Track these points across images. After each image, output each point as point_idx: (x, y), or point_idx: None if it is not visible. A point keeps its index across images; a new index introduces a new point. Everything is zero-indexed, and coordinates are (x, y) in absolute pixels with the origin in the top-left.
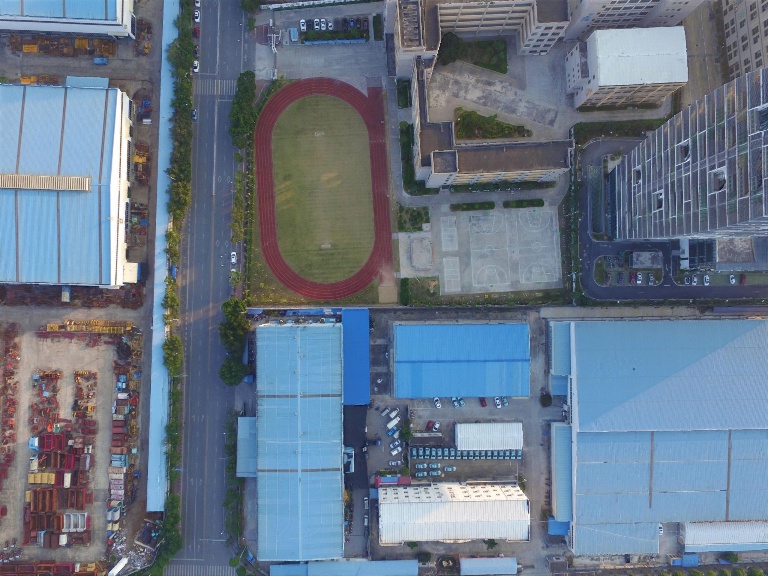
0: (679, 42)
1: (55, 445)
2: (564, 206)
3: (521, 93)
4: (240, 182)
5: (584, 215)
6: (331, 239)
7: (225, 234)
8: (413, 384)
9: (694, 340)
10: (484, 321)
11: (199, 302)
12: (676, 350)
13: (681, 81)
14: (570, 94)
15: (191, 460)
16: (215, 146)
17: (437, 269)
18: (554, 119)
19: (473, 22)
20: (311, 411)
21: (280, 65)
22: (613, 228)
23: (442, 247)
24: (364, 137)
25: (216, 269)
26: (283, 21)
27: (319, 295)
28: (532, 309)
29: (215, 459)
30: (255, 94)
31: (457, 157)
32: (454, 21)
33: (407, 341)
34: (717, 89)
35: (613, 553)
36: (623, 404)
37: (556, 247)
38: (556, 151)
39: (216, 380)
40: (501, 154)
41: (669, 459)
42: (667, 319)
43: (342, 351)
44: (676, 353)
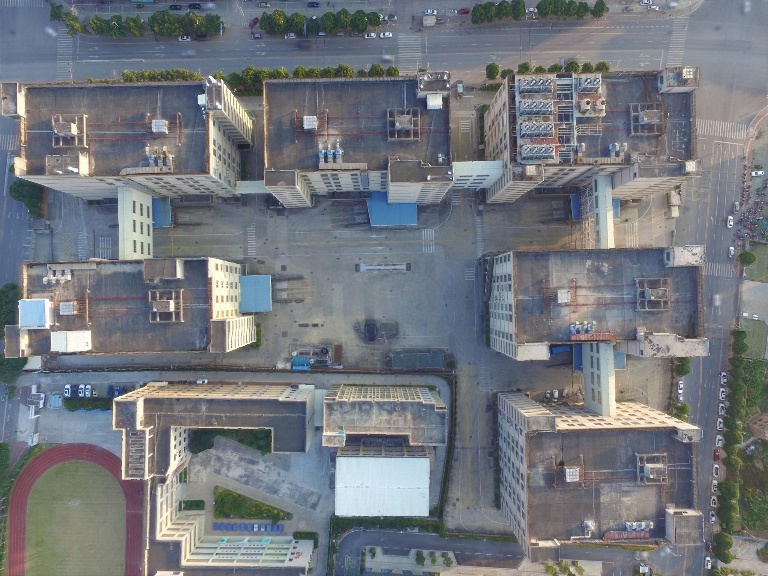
0: (422, 475)
1: None
2: None
3: (285, 474)
4: None
5: None
6: None
7: None
8: None
9: None
10: None
11: None
12: None
13: (421, 515)
14: None
15: None
16: None
17: None
18: (317, 503)
19: None
20: None
21: (42, 428)
22: None
23: None
24: (121, 507)
25: None
26: (49, 383)
27: None
28: None
29: None
30: (13, 458)
31: None
32: None
33: None
34: None
35: None
36: None
37: None
38: (288, 575)
39: None
40: (231, 575)
41: None
42: None
43: None
44: None
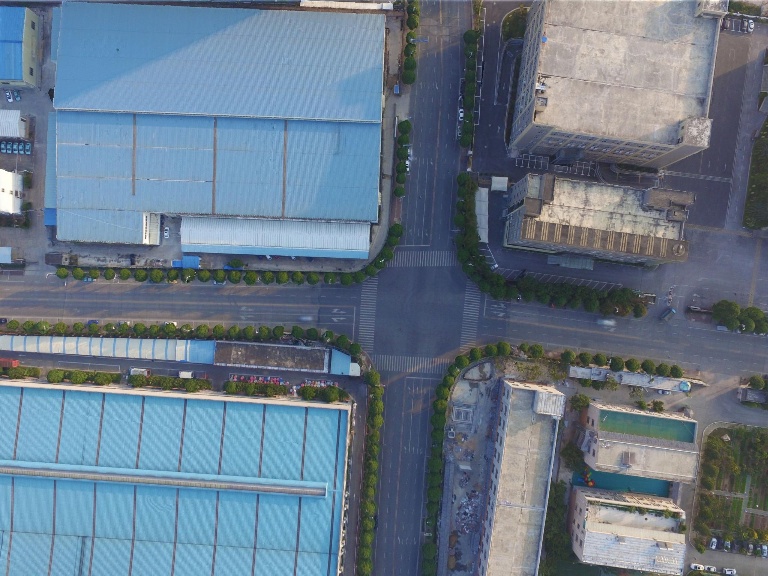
0: None
1: None
2: None
3: None
4: None
5: None
6: None
7: None
8: None
9: (184, 25)
10: None
11: None
12: (164, 34)
13: None
14: None
15: None
16: None
17: None
18: None
19: None
20: None
21: None
22: None
23: None
24: None
25: None
26: None
27: None
28: (51, 5)
29: None
30: None
31: None
32: None
33: None
34: None
35: (96, 240)
36: (102, 83)
37: None
38: None
39: None
40: None
41: (152, 145)
42: None
43: None
44: (163, 37)
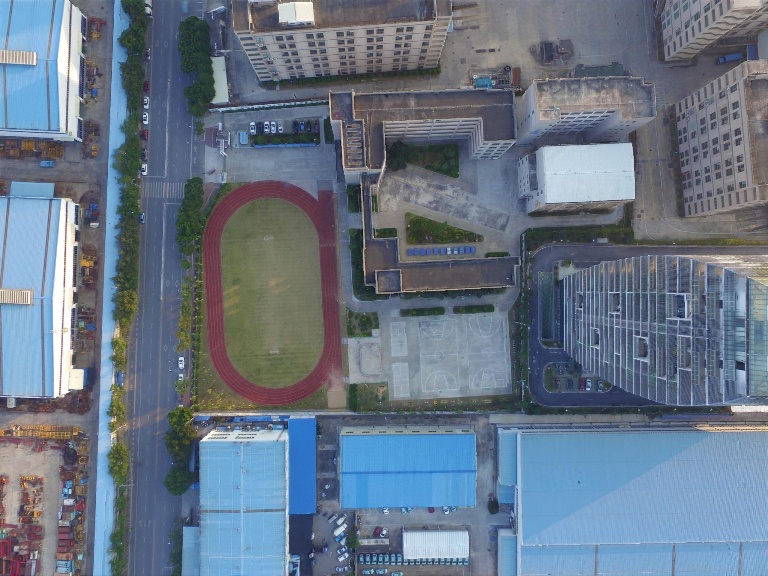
0: (627, 159)
1: (0, 551)
2: (514, 312)
3: (473, 198)
4: (187, 289)
5: (534, 321)
6: (280, 344)
7: (173, 339)
8: (359, 495)
9: (640, 453)
10: (433, 427)
11: (146, 407)
12: (621, 463)
13: (628, 198)
14: (522, 199)
15: (138, 565)
16: (163, 250)
17: (386, 375)
18: (506, 224)
19: (422, 131)
20: (254, 526)
21: (230, 168)
22: (561, 338)
23: (391, 352)
24: (314, 241)
25: (164, 374)
26: (233, 123)
27: (267, 400)
28: (481, 415)
29: (162, 564)
30: (204, 198)
31: (401, 277)
32: (403, 131)
33: (353, 452)
34: (642, 257)
35: None
36: (567, 518)
37: (506, 353)
38: (502, 267)
39: (163, 485)
40: (447, 271)
41: (613, 571)
42: (615, 427)
43: (288, 461)
44: (621, 466)
